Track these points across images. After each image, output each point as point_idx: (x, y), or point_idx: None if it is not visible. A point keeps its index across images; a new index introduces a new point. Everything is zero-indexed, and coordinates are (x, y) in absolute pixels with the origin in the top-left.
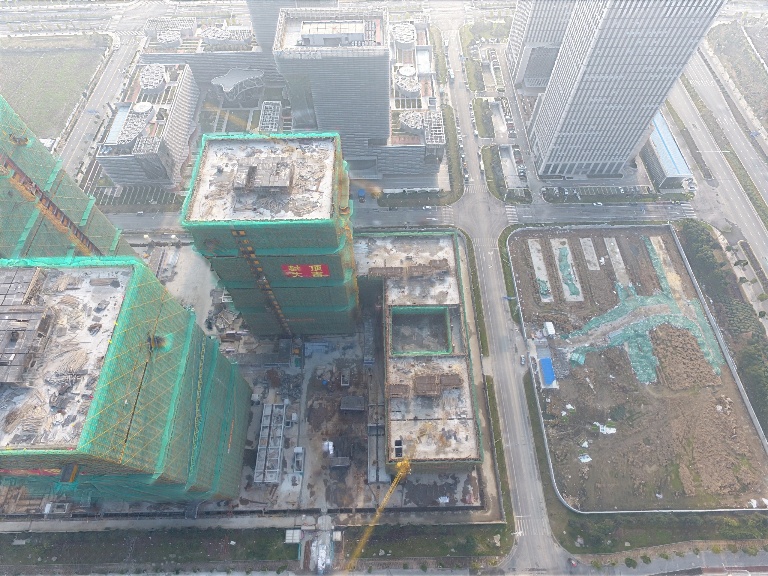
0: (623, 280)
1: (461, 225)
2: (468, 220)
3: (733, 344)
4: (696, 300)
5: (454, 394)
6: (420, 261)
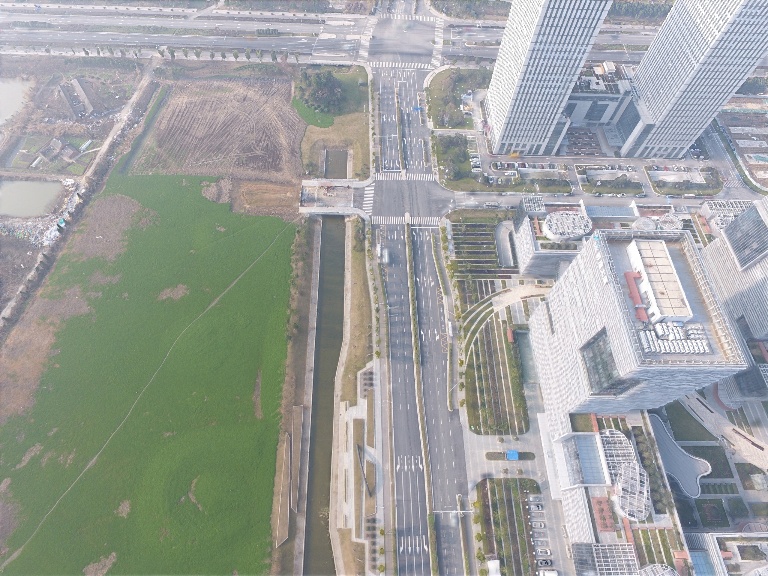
0: (767, 131)
1: None
2: None
3: None
4: (764, 100)
5: None
6: None
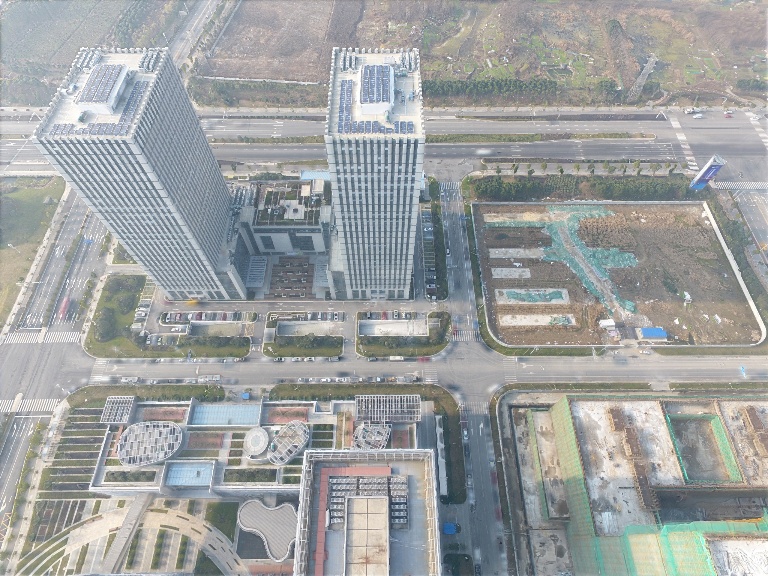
0: (538, 253)
1: (488, 394)
2: (480, 385)
3: (586, 196)
4: (548, 207)
5: (760, 417)
6: (611, 442)
